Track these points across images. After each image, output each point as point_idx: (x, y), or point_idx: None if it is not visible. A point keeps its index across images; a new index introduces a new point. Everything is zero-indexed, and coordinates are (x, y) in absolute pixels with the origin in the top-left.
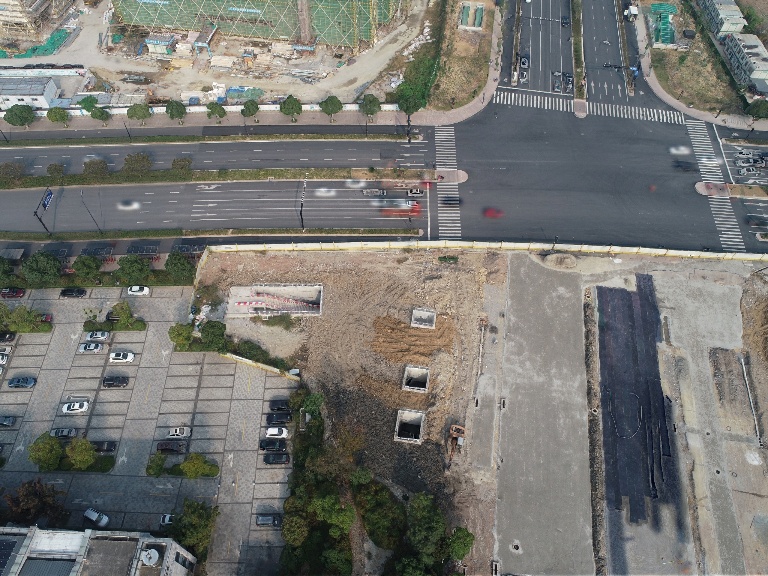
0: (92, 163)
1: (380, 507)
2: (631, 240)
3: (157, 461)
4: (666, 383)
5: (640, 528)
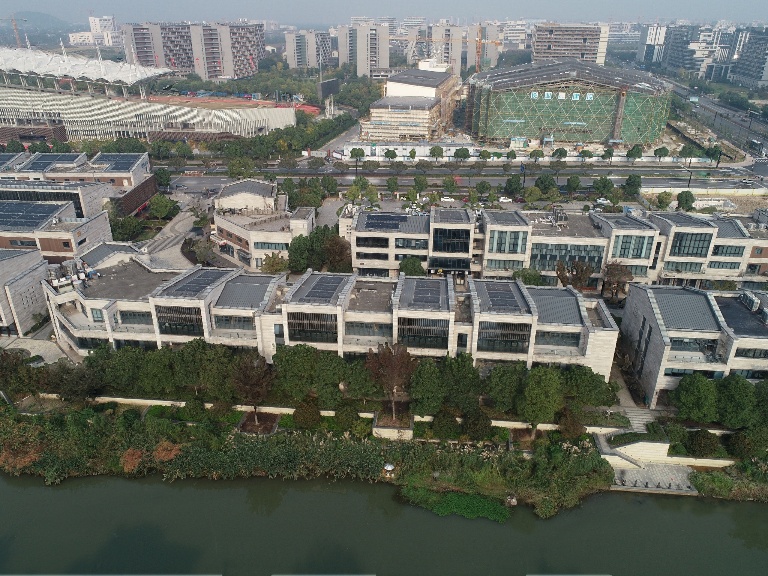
0: (530, 164)
1: None
2: None
3: None
4: None
5: None
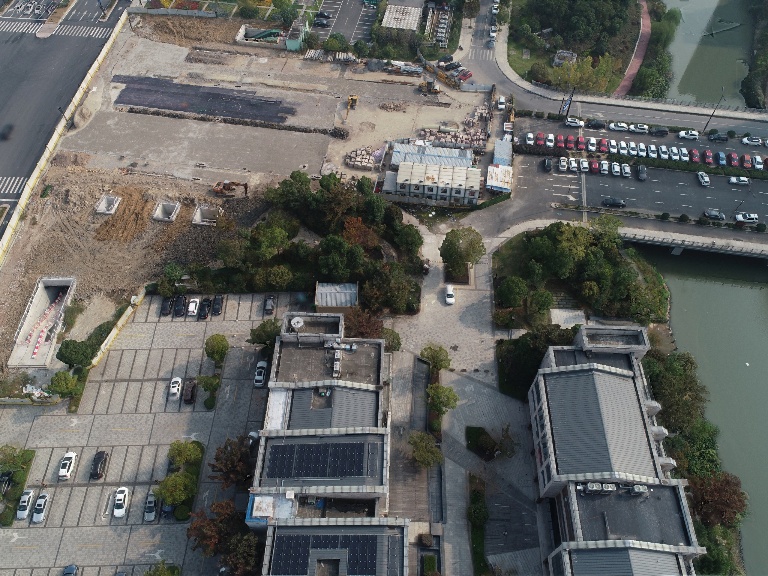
0: None
1: (270, 226)
2: (77, 78)
3: (206, 378)
4: (205, 84)
5: (298, 111)
